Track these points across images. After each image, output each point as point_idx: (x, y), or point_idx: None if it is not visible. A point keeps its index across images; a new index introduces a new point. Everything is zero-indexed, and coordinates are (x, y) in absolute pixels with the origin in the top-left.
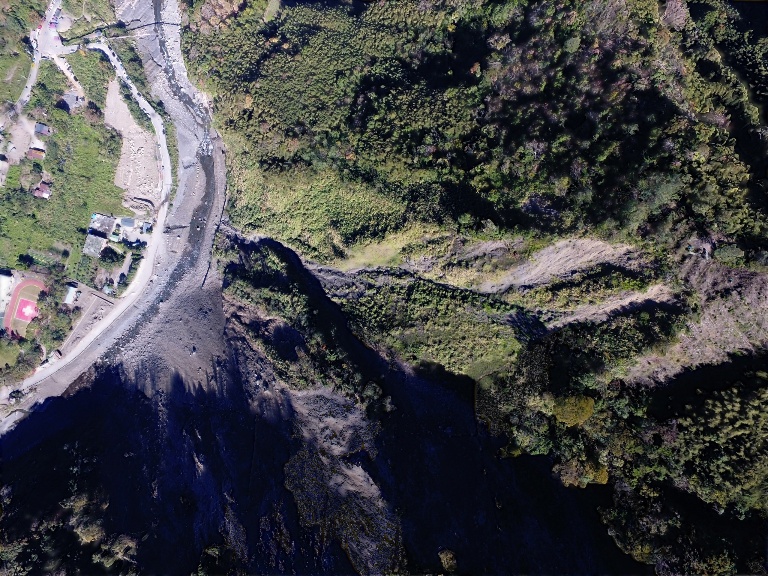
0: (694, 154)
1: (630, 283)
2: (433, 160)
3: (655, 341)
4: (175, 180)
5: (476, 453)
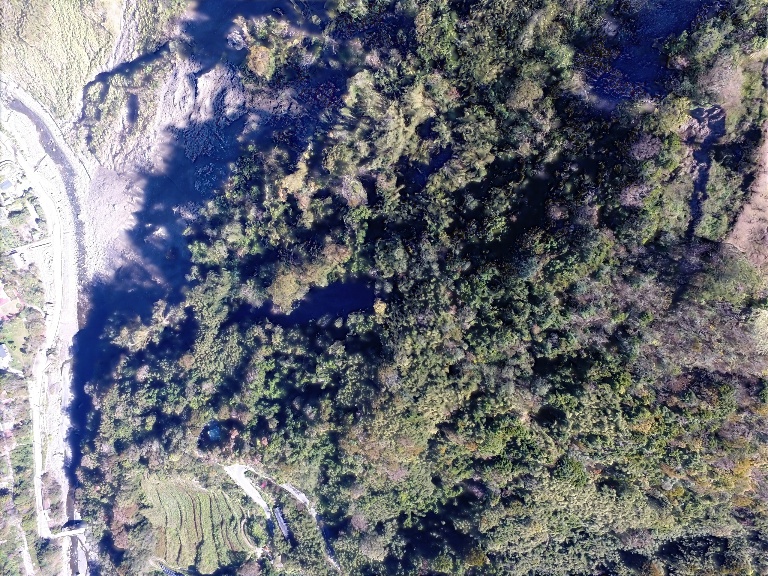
0: None
1: None
2: None
3: None
4: (8, 134)
5: None
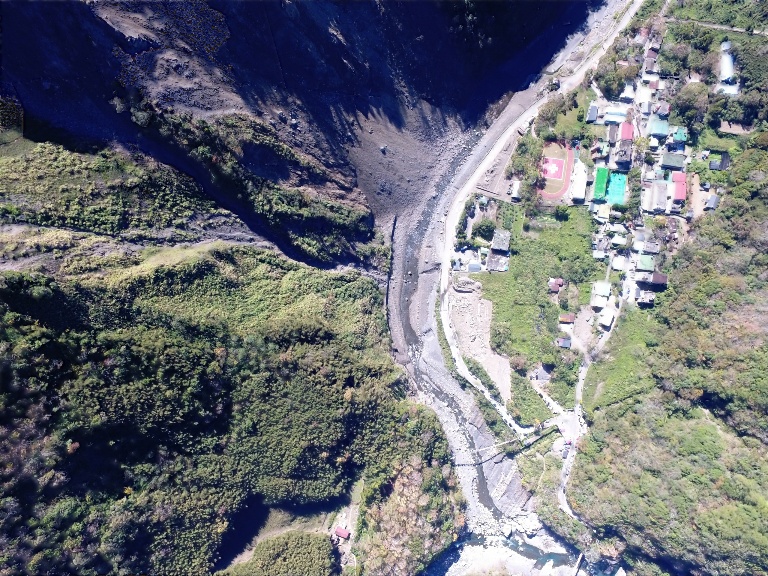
0: None
1: None
2: (106, 351)
3: None
4: (438, 316)
5: (5, 63)
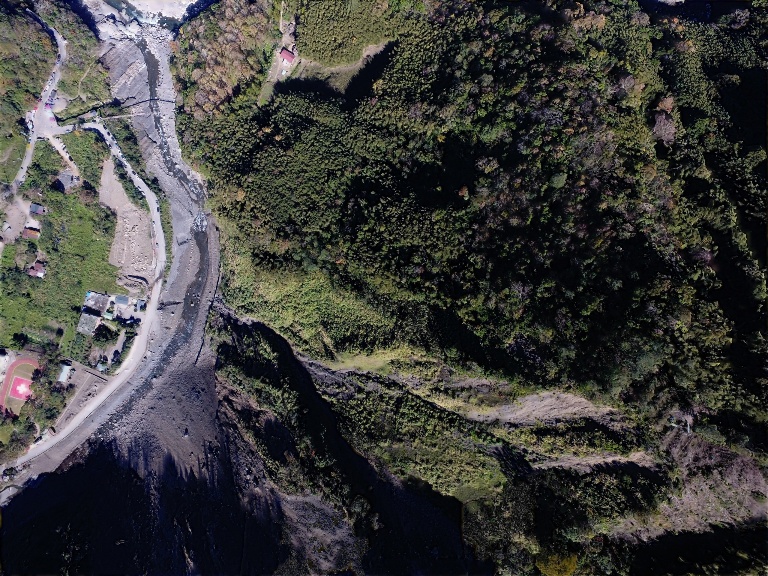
0: (676, 323)
1: (613, 446)
2: (421, 281)
3: (637, 508)
4: (169, 257)
5: None
